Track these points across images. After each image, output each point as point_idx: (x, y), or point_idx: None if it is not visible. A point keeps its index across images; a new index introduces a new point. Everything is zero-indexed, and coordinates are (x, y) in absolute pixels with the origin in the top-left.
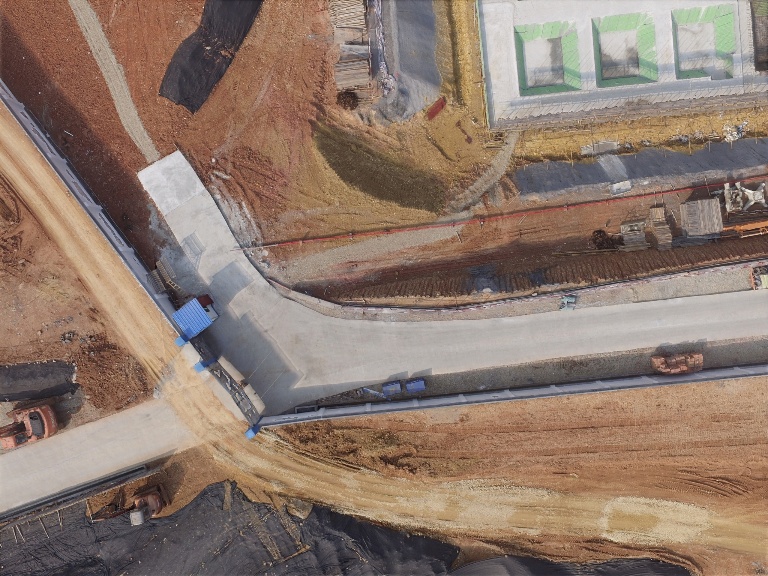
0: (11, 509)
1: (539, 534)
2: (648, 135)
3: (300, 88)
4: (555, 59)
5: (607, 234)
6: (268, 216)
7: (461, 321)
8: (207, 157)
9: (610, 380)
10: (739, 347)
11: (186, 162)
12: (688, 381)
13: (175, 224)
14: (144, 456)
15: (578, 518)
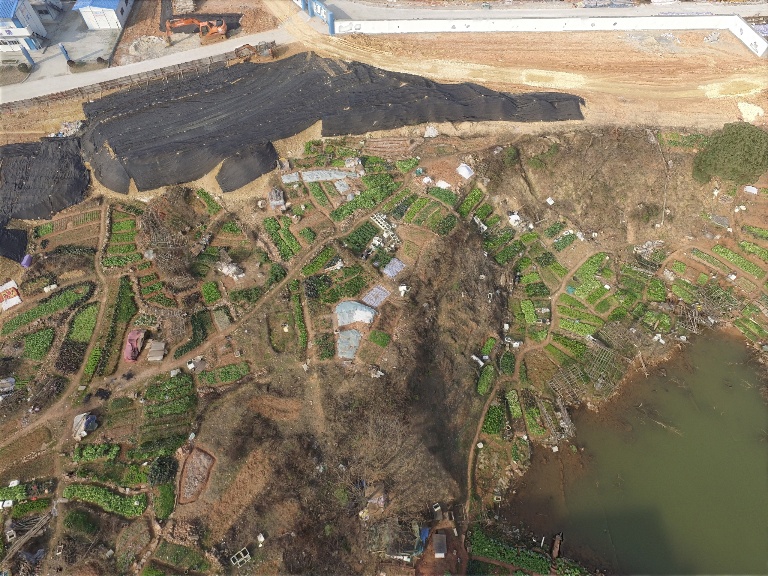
0: None
1: (486, 81)
2: None
3: None
4: None
5: None
6: None
7: (435, 10)
8: None
9: None
10: None
11: None
12: (548, 17)
13: None
14: None
15: (507, 76)
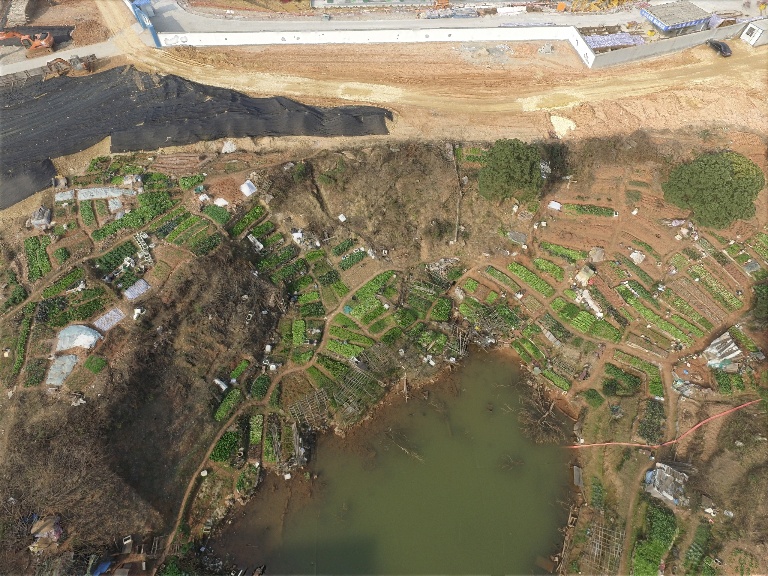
0: None
1: (301, 94)
2: None
3: None
4: (347, 0)
5: None
6: None
7: (273, 21)
8: None
9: None
10: None
11: None
12: (378, 29)
13: None
14: None
15: (324, 89)
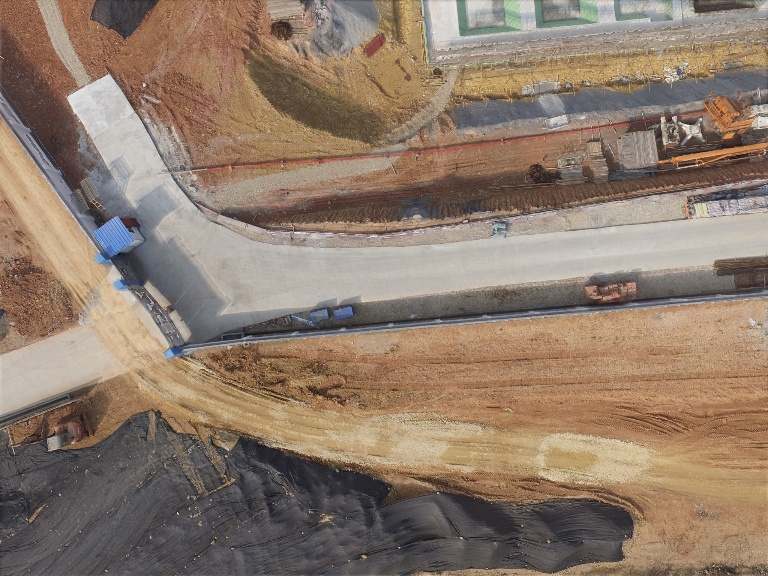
0: None
1: (473, 472)
2: (588, 75)
3: (234, 17)
4: (496, 1)
5: (544, 168)
6: (198, 141)
7: (391, 248)
8: (138, 82)
9: (543, 310)
10: (675, 278)
11: (116, 86)
12: (620, 307)
13: (103, 147)
14: (68, 385)
15: (513, 455)
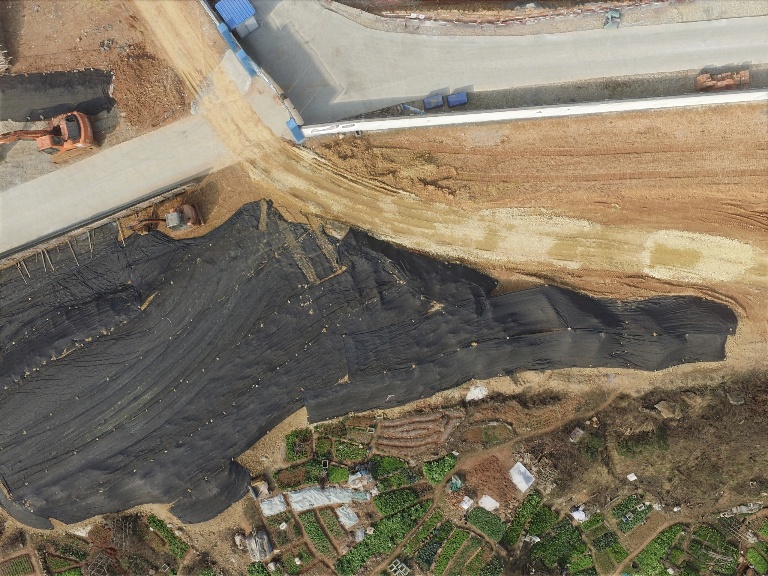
0: (41, 237)
1: (579, 268)
2: None
3: None
4: None
5: None
6: None
7: (504, 37)
8: None
9: None
10: None
11: None
12: (735, 90)
13: None
14: (179, 176)
15: (619, 251)
